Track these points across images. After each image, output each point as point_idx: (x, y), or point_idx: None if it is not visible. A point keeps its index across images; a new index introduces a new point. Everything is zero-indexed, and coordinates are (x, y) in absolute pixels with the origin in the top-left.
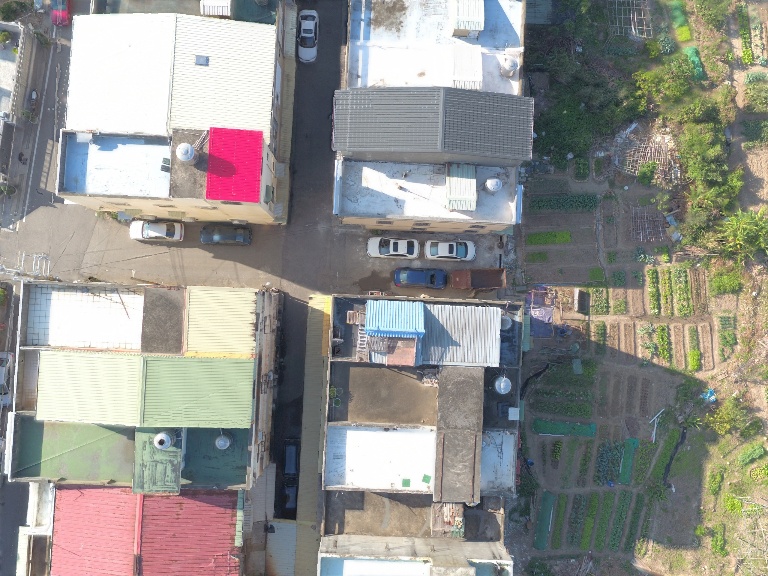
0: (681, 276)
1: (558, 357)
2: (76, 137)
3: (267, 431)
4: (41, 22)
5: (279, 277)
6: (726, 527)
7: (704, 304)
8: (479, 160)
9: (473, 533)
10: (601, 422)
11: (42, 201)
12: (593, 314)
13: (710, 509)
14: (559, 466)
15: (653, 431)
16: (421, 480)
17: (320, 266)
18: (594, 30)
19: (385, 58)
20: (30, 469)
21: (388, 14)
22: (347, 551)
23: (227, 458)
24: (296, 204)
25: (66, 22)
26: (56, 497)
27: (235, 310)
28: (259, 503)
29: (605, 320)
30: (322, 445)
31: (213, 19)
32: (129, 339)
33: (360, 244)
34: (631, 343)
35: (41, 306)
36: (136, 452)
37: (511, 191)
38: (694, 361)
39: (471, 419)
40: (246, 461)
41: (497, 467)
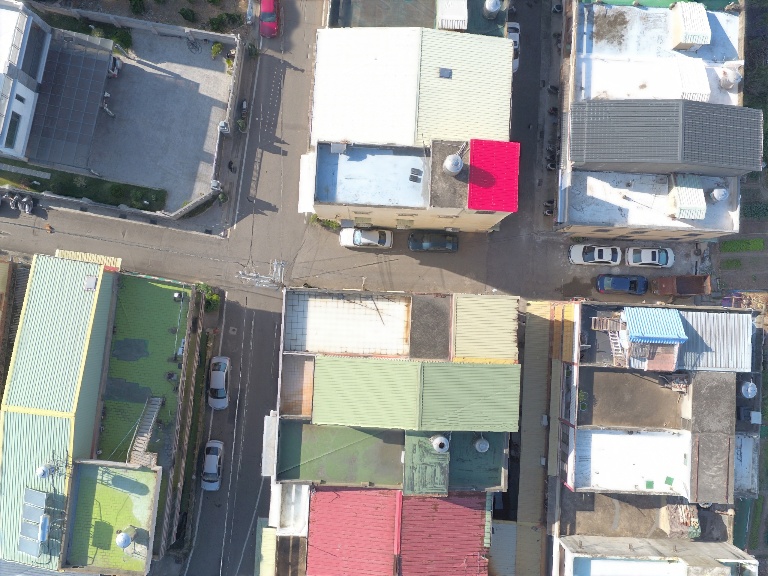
0: None
1: None
2: (326, 148)
3: None
4: (248, 33)
5: (484, 283)
6: None
7: None
8: (708, 170)
9: None
10: None
11: (252, 209)
12: None
13: None
14: None
15: None
16: (664, 482)
17: (523, 273)
18: None
19: (608, 70)
20: (290, 472)
21: (609, 28)
22: (596, 551)
23: (480, 461)
24: None
25: (275, 34)
26: (311, 499)
27: (498, 317)
28: None
29: None
30: (552, 448)
31: (455, 33)
32: (384, 345)
33: (561, 251)
34: None
35: (298, 313)
36: (406, 455)
37: (731, 200)
38: None
39: (724, 423)
40: (498, 464)
41: (737, 469)
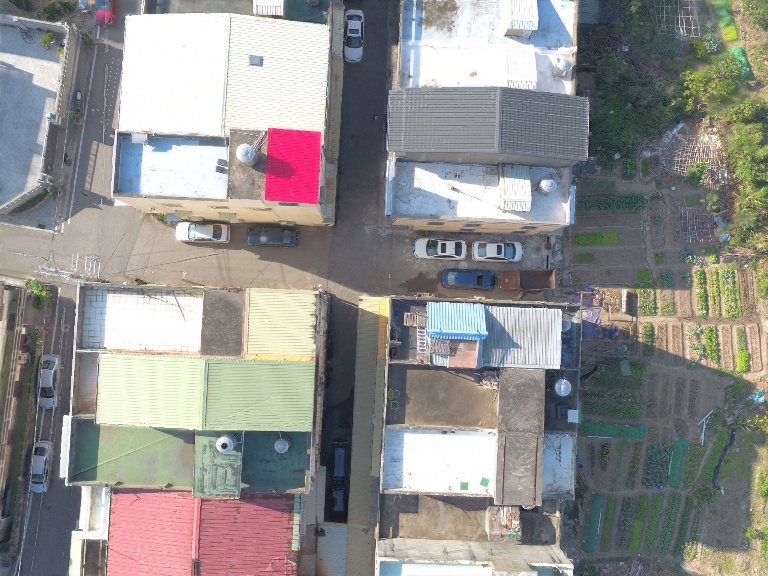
0: (729, 277)
1: (606, 359)
2: (130, 138)
3: None
4: (85, 22)
5: (326, 279)
6: None
7: (752, 305)
8: (534, 160)
9: (528, 536)
10: (649, 424)
11: (87, 203)
12: (641, 315)
13: (759, 511)
14: (607, 468)
15: (702, 433)
16: (479, 483)
17: (367, 267)
18: (642, 30)
19: (437, 58)
20: (86, 473)
21: (439, 14)
22: (406, 555)
23: (285, 461)
24: (342, 205)
25: (111, 22)
26: (111, 501)
27: (295, 312)
28: (310, 506)
29: (653, 321)
30: (375, 448)
31: (267, 19)
32: (185, 342)
33: (407, 245)
34: (679, 344)
35: (97, 308)
36: (196, 456)
37: (564, 192)
38: (742, 362)
39: (532, 422)
40: (304, 464)
41: (555, 470)
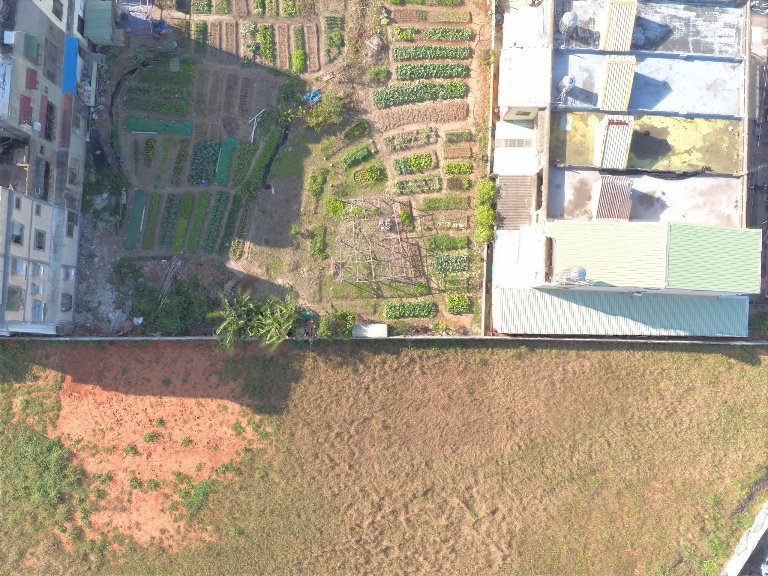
0: None
1: (155, 55)
2: None
3: None
4: None
5: None
6: (327, 230)
7: (310, 4)
8: None
9: None
10: (198, 121)
11: None
12: (194, 13)
13: (310, 211)
14: (152, 165)
15: (252, 131)
16: None
17: None
18: None
19: None
20: None
21: None
22: None
23: None
24: None
25: None
26: None
27: None
28: None
29: (207, 19)
30: None
31: None
32: None
33: None
34: (233, 42)
35: None
36: None
37: None
38: (297, 60)
39: None
40: None
41: None
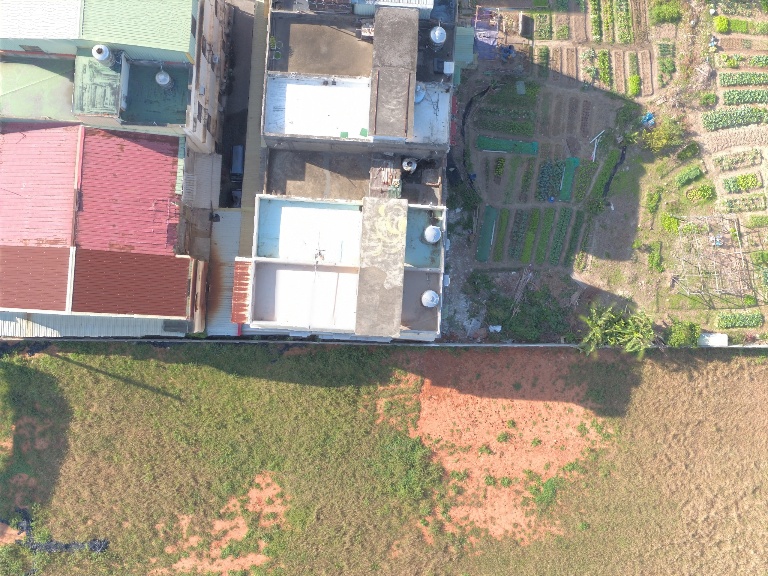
0: (622, 4)
1: (502, 78)
2: None
3: (213, 118)
4: None
5: None
6: (663, 245)
7: (644, 32)
8: None
9: None
10: (543, 141)
11: None
12: (537, 39)
13: (647, 227)
14: (502, 182)
15: (593, 151)
16: (359, 134)
17: None
18: None
19: None
20: None
21: None
22: None
23: (168, 102)
24: None
25: None
26: None
27: None
28: (204, 190)
29: (548, 45)
30: None
31: None
32: None
33: None
34: (573, 67)
35: None
36: (76, 75)
37: None
38: (634, 85)
39: (405, 58)
40: None
41: (433, 123)
